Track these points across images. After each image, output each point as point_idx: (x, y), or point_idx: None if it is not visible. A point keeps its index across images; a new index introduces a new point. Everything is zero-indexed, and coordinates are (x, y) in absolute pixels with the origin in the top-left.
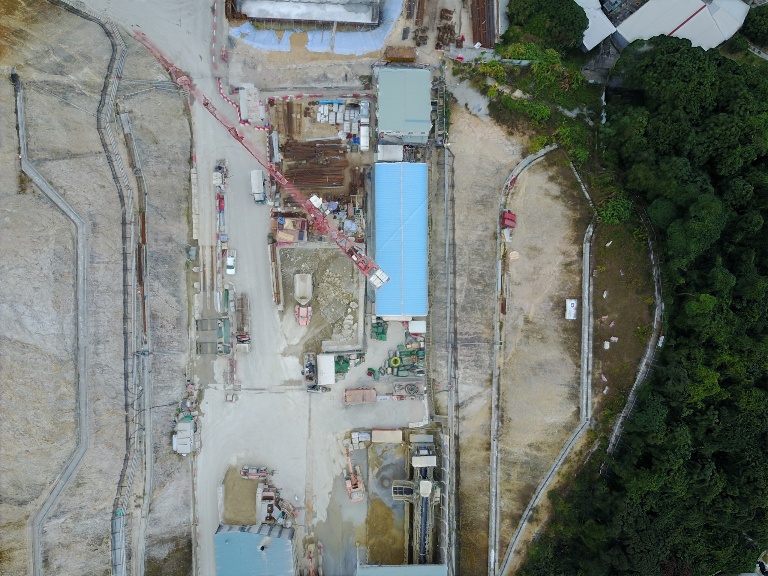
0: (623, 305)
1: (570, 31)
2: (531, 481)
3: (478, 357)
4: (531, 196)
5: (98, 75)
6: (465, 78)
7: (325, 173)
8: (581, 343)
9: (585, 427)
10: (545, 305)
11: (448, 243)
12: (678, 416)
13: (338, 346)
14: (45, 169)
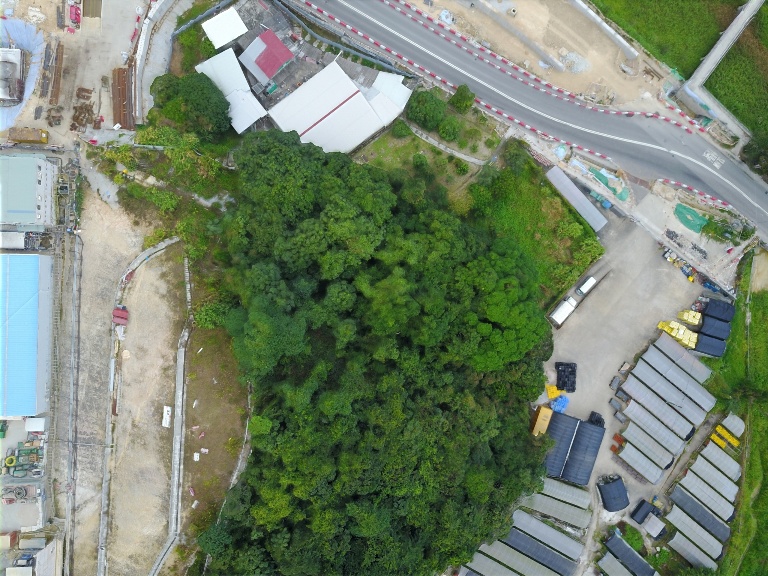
0: (215, 415)
1: (205, 116)
2: None
3: (93, 459)
4: (144, 292)
5: None
6: (97, 162)
7: None
8: (172, 454)
9: (175, 542)
10: (148, 410)
11: (73, 336)
12: None
13: None
14: None
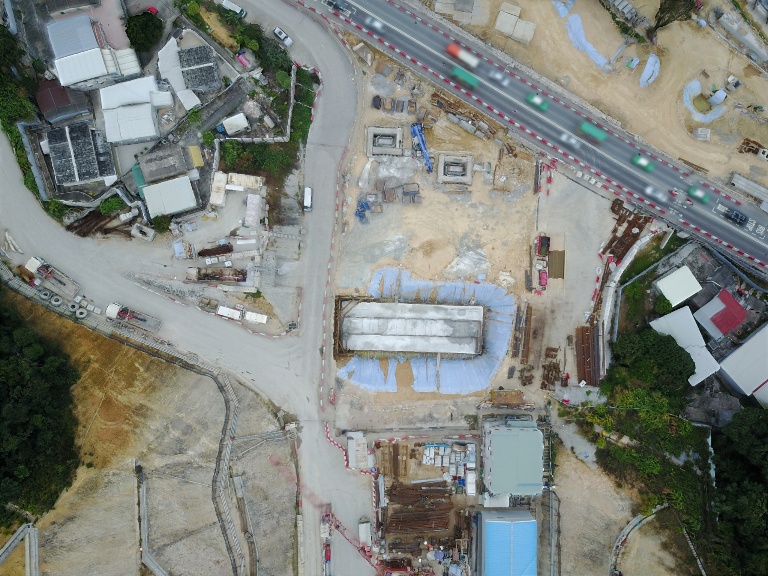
0: None
1: (678, 379)
2: None
3: None
4: (643, 561)
5: (213, 441)
6: (571, 421)
7: (430, 517)
8: None
9: None
10: None
11: None
12: None
13: None
14: (164, 557)
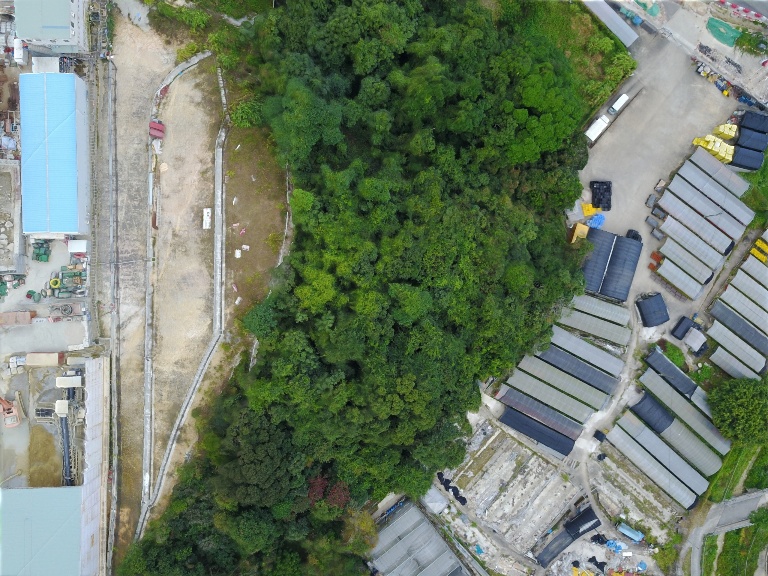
0: (254, 212)
1: None
2: (177, 400)
3: (135, 275)
4: (179, 105)
5: None
6: None
7: None
8: (214, 253)
9: (220, 340)
10: (188, 216)
11: (111, 159)
12: (311, 326)
13: None
14: None
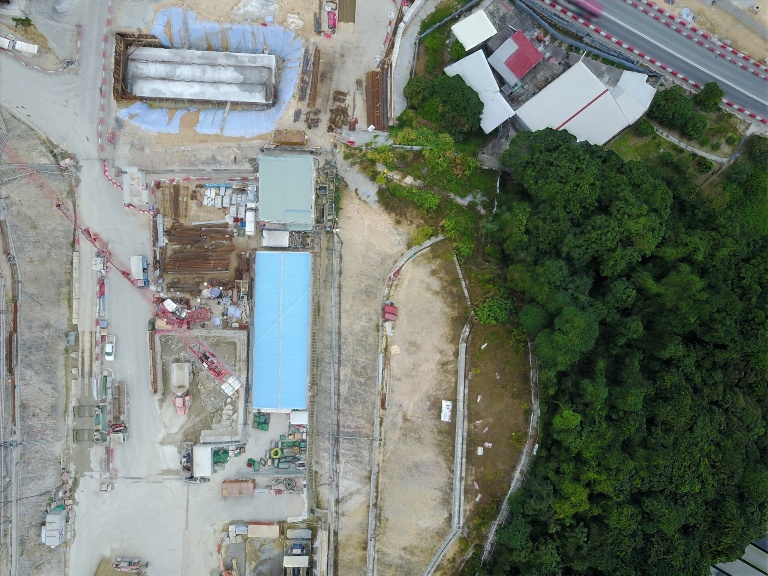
0: (498, 410)
1: (463, 117)
2: None
3: (358, 452)
4: (413, 289)
5: None
6: (355, 163)
7: (210, 258)
8: (454, 447)
9: (457, 535)
10: (423, 404)
11: (334, 332)
12: None
13: (216, 437)
14: None
